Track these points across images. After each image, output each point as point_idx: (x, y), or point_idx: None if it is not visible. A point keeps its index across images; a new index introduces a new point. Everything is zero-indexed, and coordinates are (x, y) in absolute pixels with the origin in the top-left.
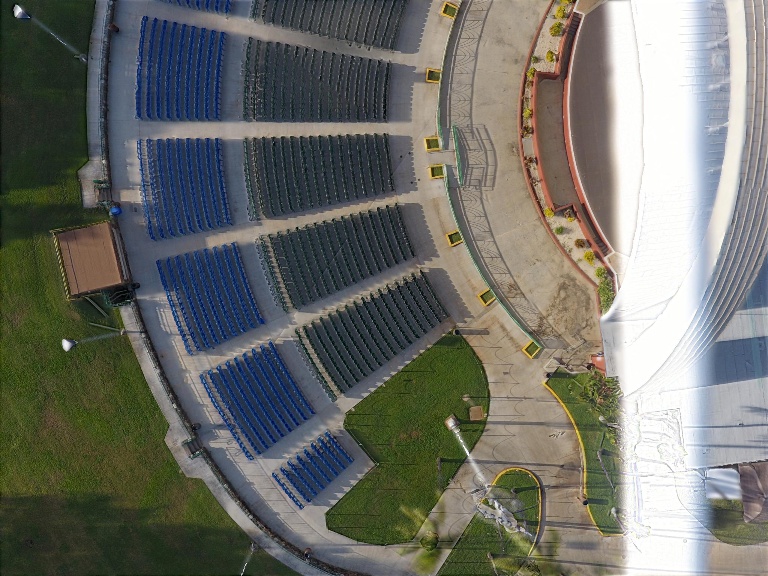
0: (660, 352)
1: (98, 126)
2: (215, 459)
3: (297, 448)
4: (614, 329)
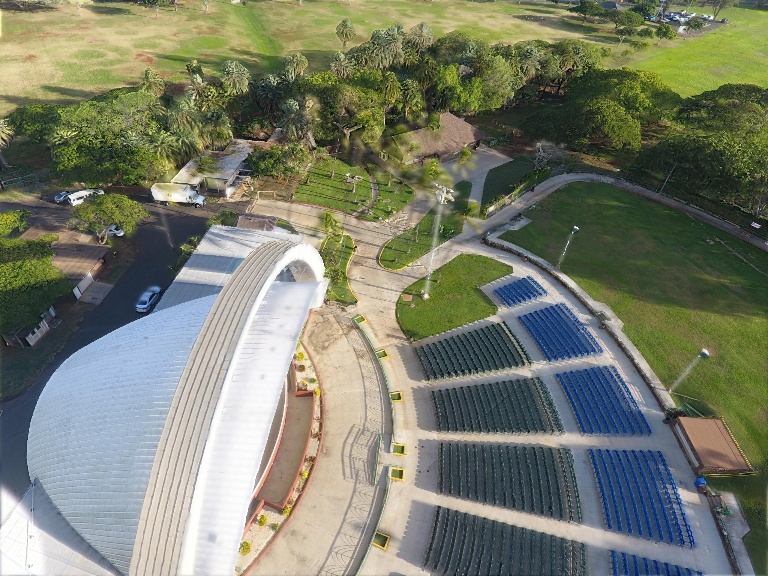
0: (316, 255)
1: (743, 574)
2: (587, 310)
3: (530, 304)
4: None
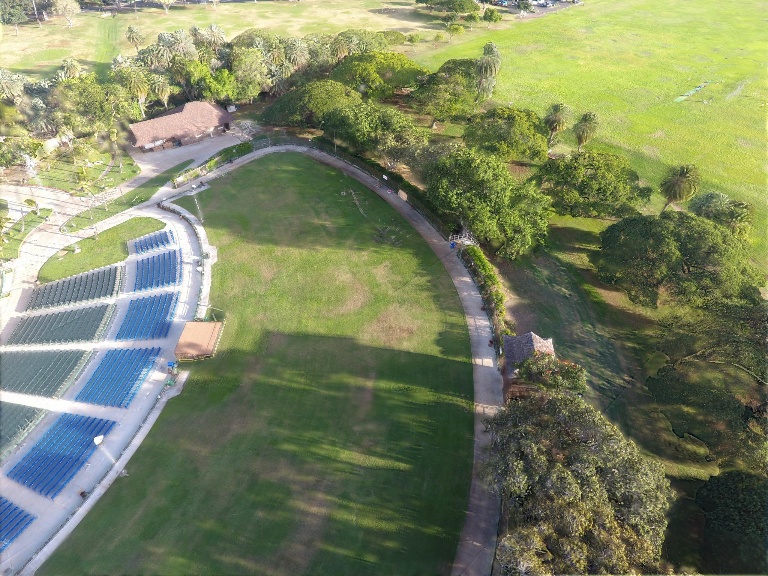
0: None
1: (147, 421)
2: (200, 253)
3: (158, 251)
4: None
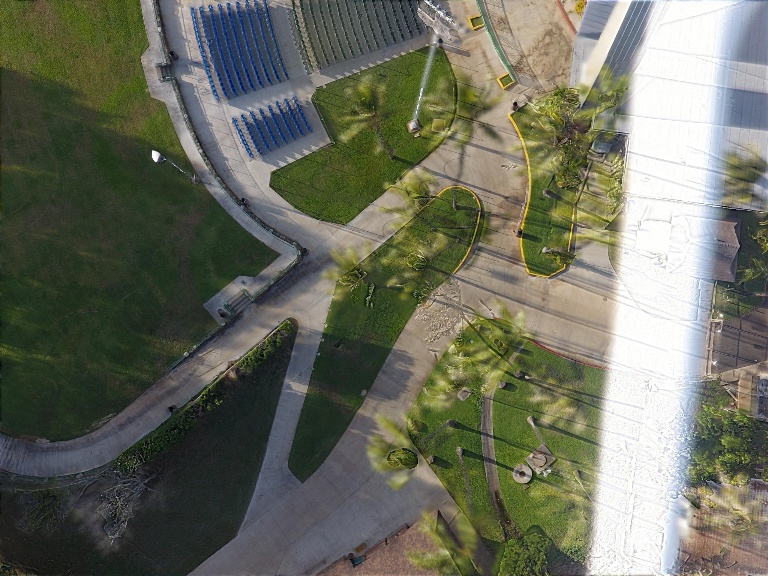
0: (622, 10)
1: None
2: (183, 92)
3: (262, 105)
4: (586, 45)
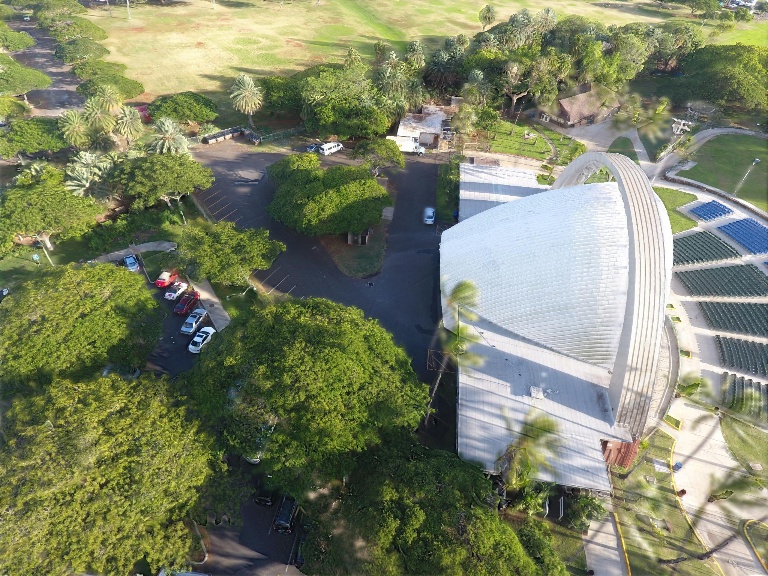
0: None
1: None
2: None
3: (722, 220)
4: None
